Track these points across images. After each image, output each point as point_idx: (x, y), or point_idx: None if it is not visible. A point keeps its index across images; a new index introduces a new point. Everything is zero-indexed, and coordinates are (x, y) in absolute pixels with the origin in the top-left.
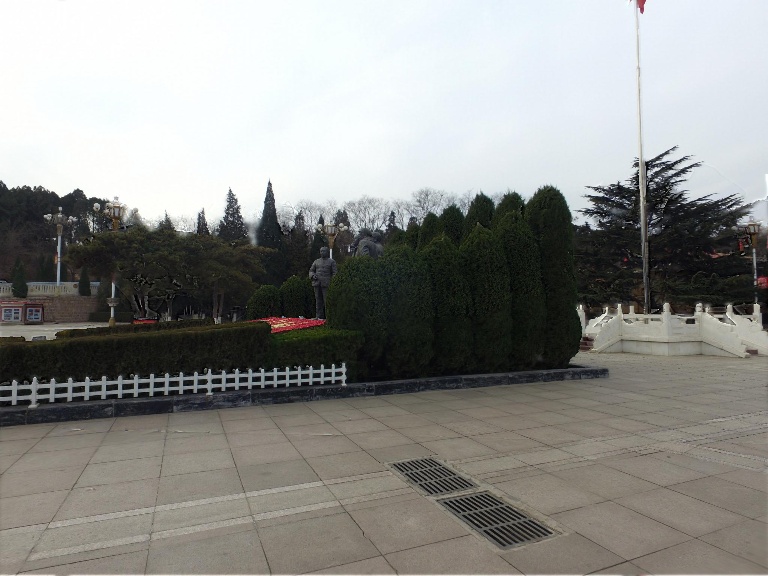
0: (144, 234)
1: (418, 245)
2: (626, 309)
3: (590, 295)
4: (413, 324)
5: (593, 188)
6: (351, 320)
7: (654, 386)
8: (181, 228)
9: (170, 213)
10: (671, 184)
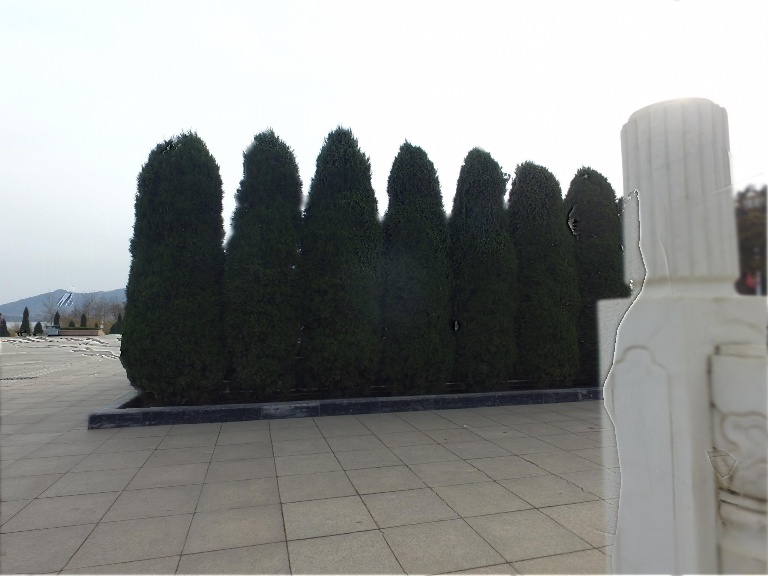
0: None
1: None
2: None
3: None
4: None
5: None
6: None
7: None
8: None
9: None
10: None
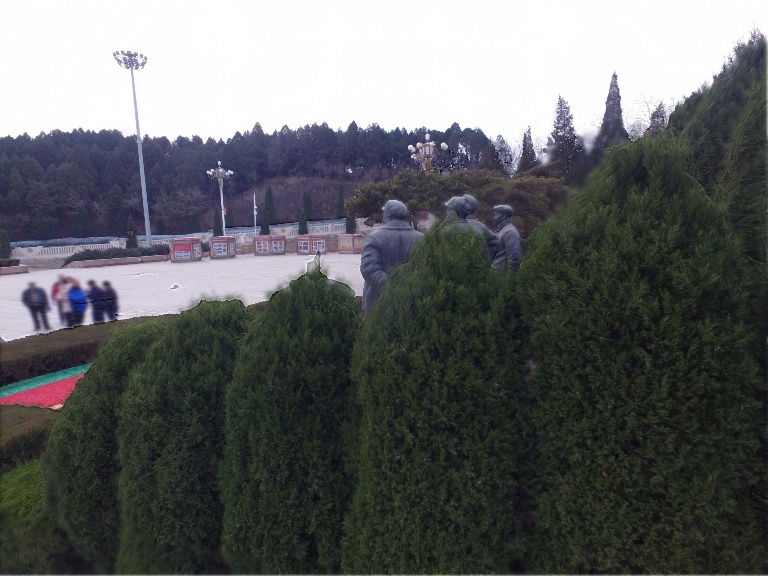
0: (404, 180)
1: None
2: None
3: None
4: (133, 546)
5: None
6: (45, 487)
7: None
8: (505, 154)
9: (495, 139)
10: None
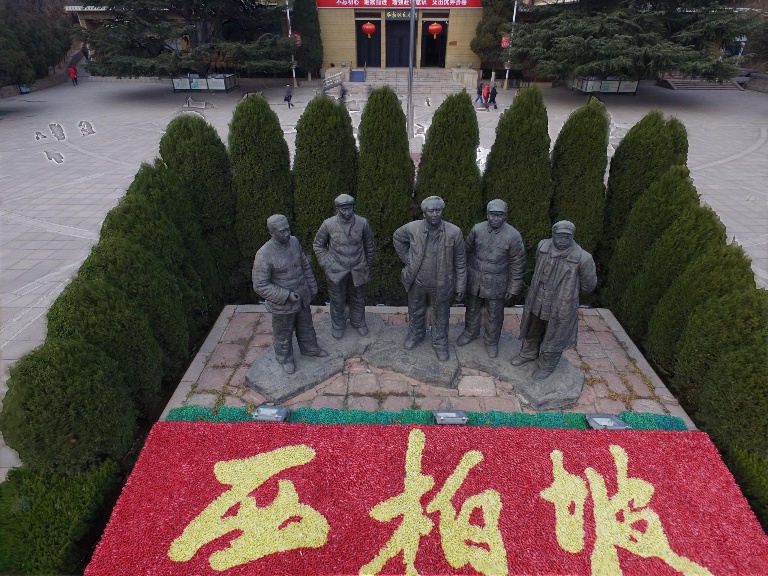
0: None
1: (381, 155)
2: (192, 76)
3: (151, 61)
4: None
5: None
6: None
7: None
8: None
9: None
10: None
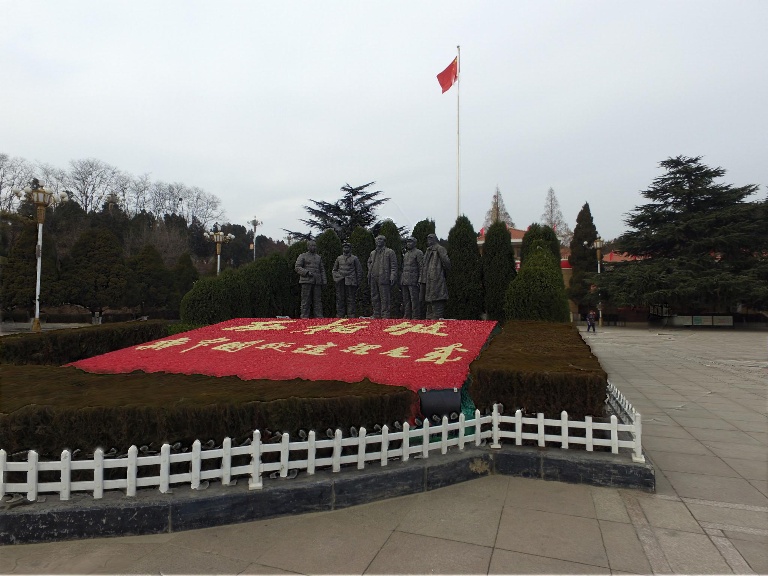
0: None
1: None
2: None
3: None
4: None
5: (315, 202)
6: None
7: (611, 356)
8: None
9: None
10: (371, 211)
